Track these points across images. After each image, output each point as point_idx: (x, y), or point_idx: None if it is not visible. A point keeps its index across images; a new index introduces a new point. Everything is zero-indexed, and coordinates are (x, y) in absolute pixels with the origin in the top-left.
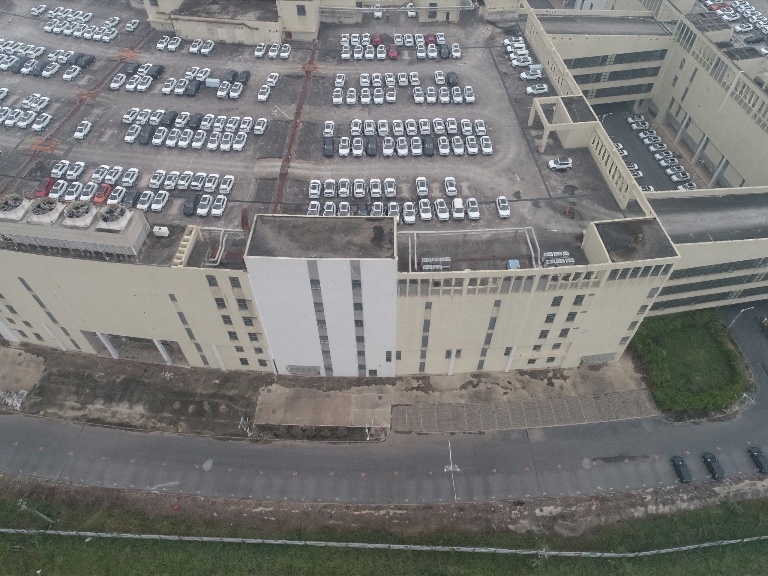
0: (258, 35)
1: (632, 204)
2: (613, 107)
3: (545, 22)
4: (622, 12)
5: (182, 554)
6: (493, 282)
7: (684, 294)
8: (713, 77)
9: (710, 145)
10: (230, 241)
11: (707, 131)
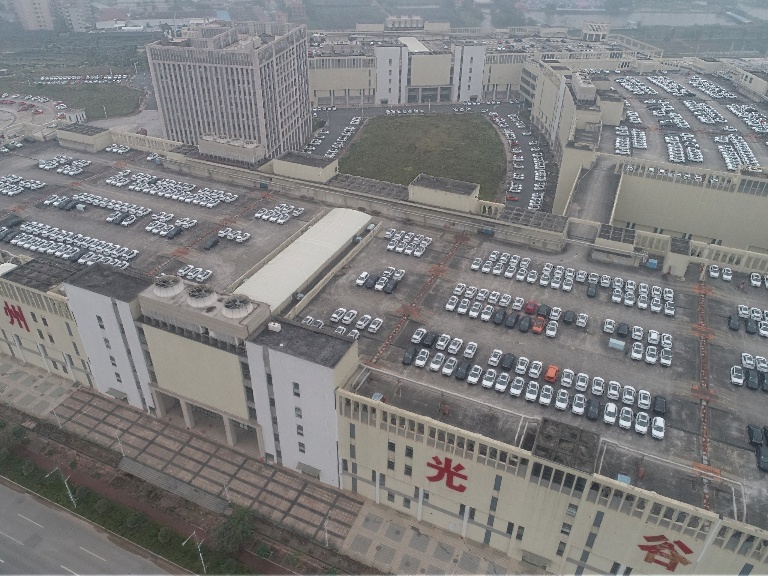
0: None
1: None
2: None
3: None
4: None
5: None
6: None
7: None
8: None
9: None
10: (761, 107)
11: None
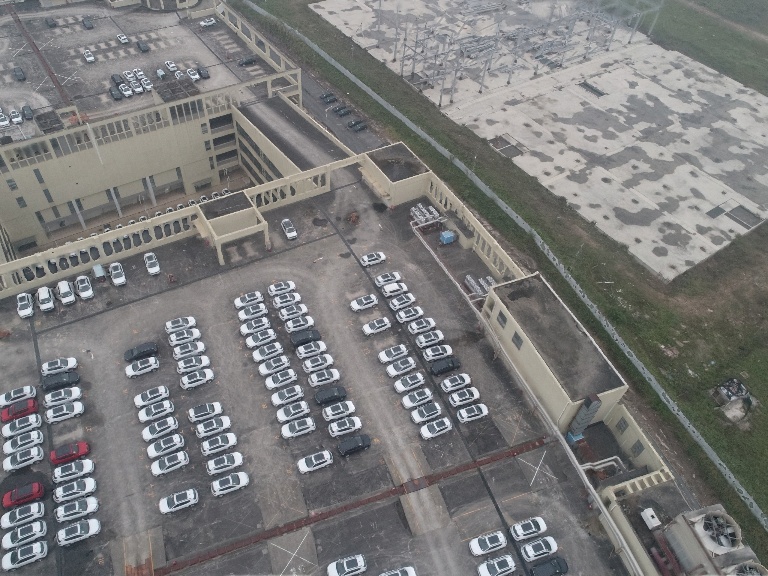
0: None
1: None
2: None
3: None
4: None
5: (739, 478)
6: (465, 251)
7: None
8: (64, 155)
9: (122, 188)
10: (564, 485)
11: (108, 185)
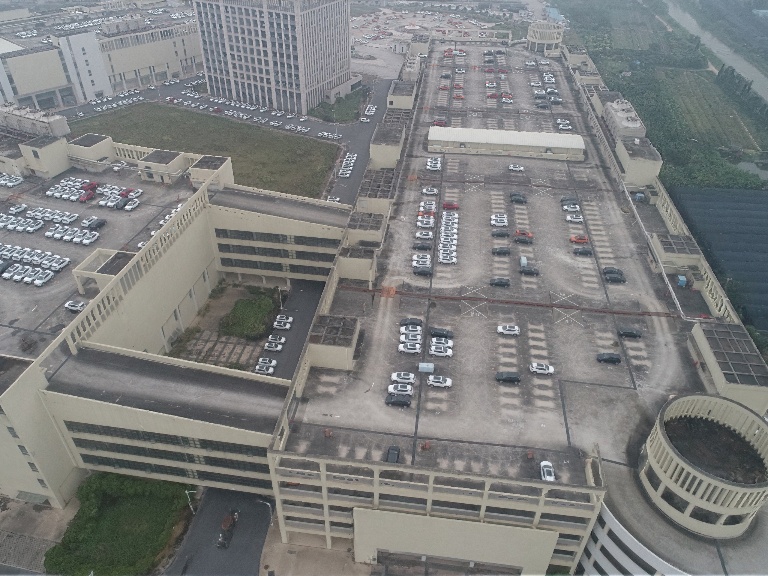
0: (7, 167)
1: (89, 353)
2: (313, 285)
3: (242, 197)
4: (325, 202)
5: None
6: None
7: (127, 456)
8: None
9: None
10: None
11: None
